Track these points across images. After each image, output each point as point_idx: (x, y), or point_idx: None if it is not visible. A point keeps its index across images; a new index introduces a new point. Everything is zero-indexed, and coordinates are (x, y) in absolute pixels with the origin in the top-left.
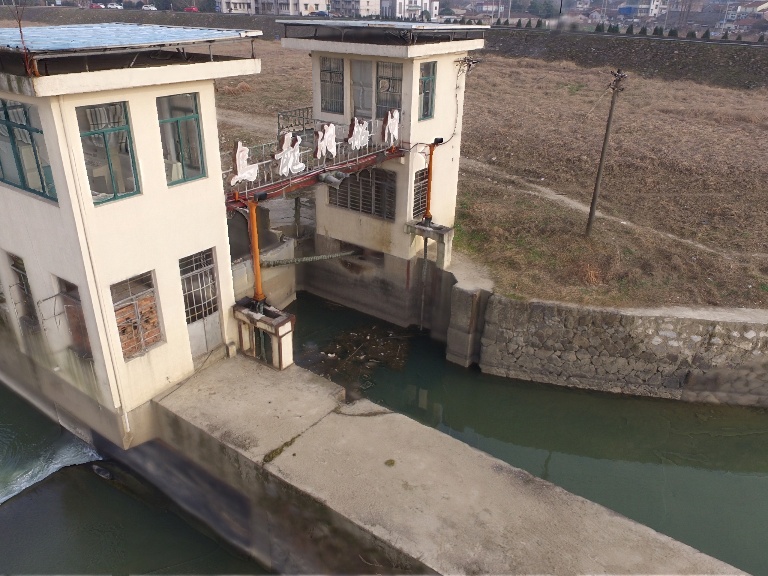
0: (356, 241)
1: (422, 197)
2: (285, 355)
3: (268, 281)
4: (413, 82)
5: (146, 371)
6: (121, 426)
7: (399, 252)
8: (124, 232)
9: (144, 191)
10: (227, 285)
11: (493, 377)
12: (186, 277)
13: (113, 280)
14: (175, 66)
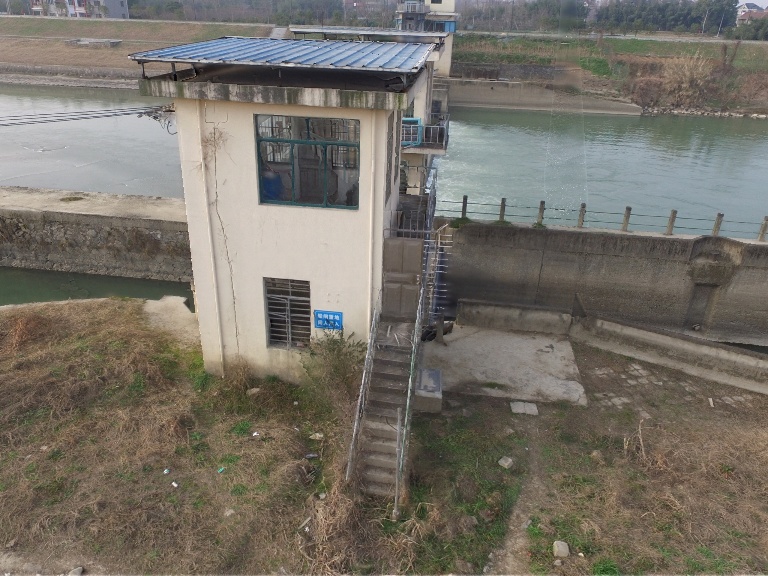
0: None
1: None
2: None
3: None
4: None
5: None
6: None
7: None
8: None
9: None
10: None
11: None
12: None
13: None
14: None
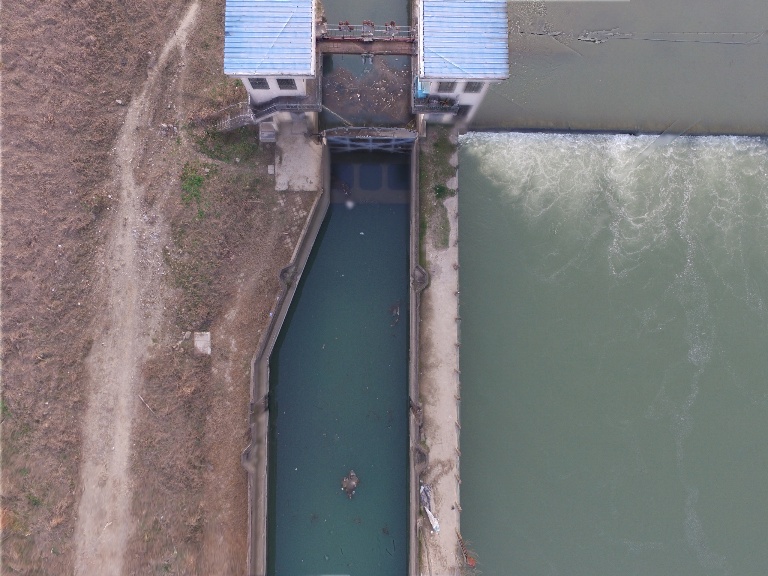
0: None
1: None
2: None
3: None
4: None
5: None
6: None
7: None
8: None
9: None
10: None
11: None
12: None
13: None
14: None
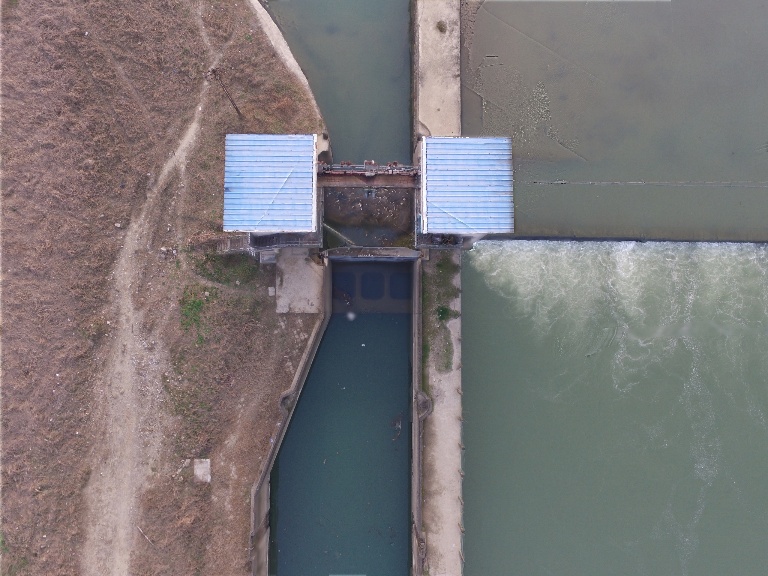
0: None
1: None
2: None
3: None
4: None
5: None
6: None
7: None
8: None
9: None
10: None
11: None
12: None
13: None
14: None
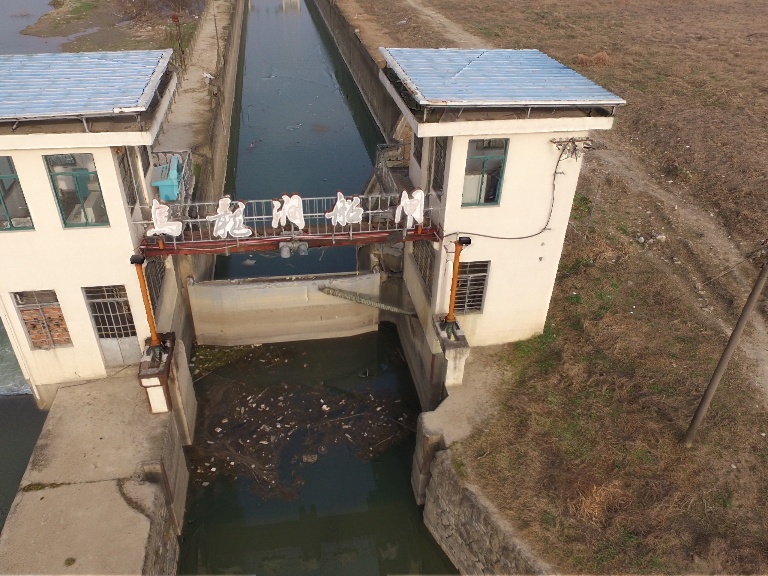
0: (415, 304)
1: (476, 291)
2: (156, 402)
3: (335, 305)
4: (452, 161)
5: (54, 361)
6: (34, 392)
7: (429, 340)
8: (19, 256)
9: (37, 228)
10: (142, 318)
11: (430, 535)
12: (96, 301)
13: (12, 289)
14: (38, 135)
